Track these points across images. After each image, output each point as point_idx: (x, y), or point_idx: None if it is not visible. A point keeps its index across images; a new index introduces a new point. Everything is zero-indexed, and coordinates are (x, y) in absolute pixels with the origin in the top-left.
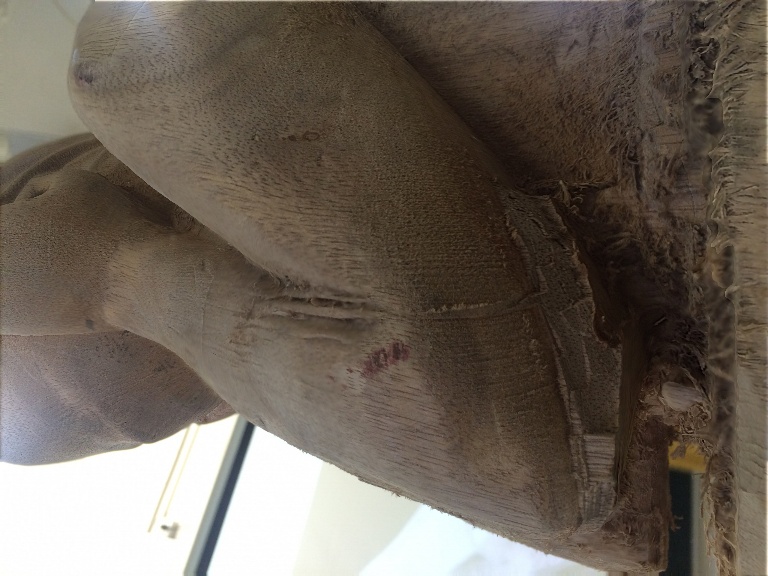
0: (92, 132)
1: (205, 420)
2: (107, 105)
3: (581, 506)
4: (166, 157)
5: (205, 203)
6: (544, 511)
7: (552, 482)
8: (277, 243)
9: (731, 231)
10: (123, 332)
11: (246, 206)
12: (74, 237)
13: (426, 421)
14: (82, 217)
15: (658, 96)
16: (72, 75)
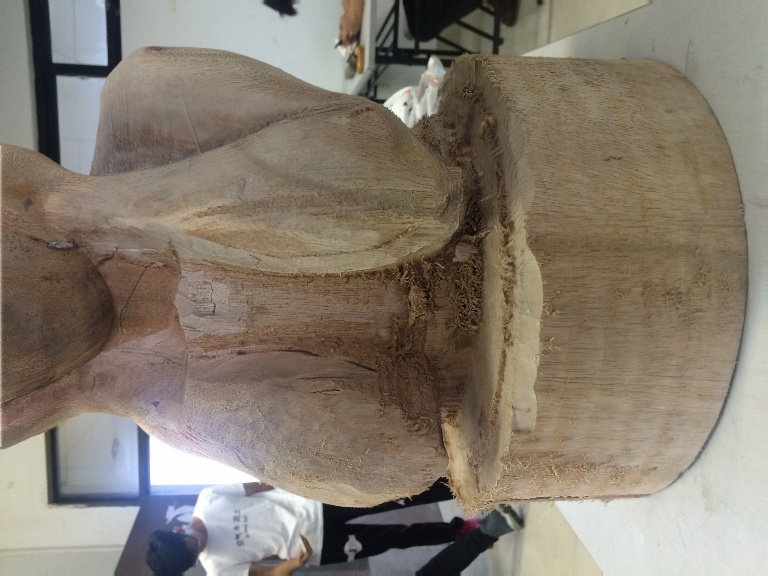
0: (129, 82)
1: None
2: (168, 59)
3: (450, 189)
4: (207, 77)
5: (230, 94)
6: (437, 177)
7: (439, 168)
8: (287, 97)
9: (498, 83)
10: (31, 239)
11: (266, 89)
12: (37, 159)
13: (381, 134)
14: (43, 157)
15: (445, 129)
16: (142, 48)
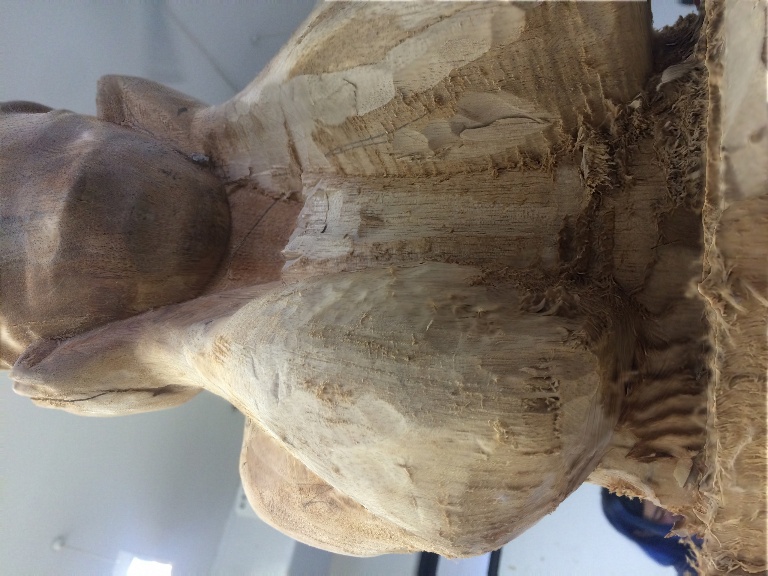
0: None
1: (33, 363)
2: None
3: None
4: None
5: None
6: None
7: None
8: None
9: None
10: None
11: None
12: None
13: None
14: None
15: None
16: None
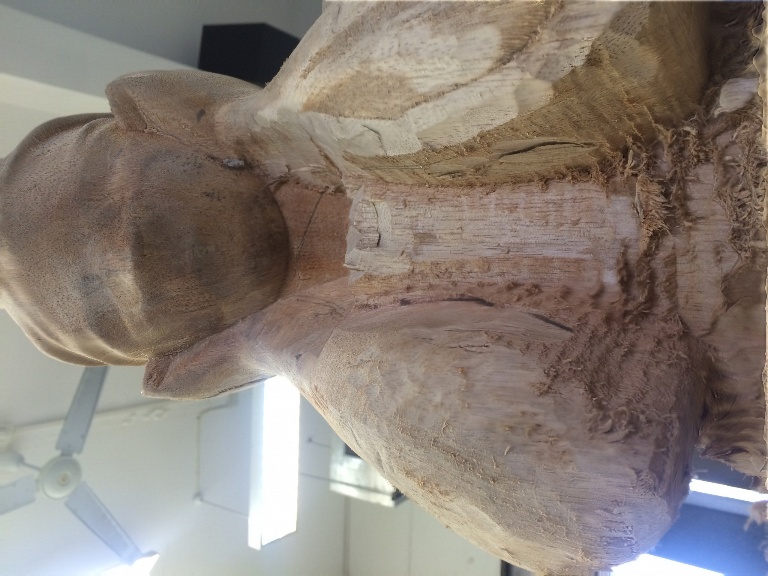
0: None
1: (158, 383)
2: None
3: None
4: None
5: None
6: None
7: None
8: None
9: None
10: (208, 157)
11: None
12: (240, 82)
13: None
14: None
15: None
16: None
